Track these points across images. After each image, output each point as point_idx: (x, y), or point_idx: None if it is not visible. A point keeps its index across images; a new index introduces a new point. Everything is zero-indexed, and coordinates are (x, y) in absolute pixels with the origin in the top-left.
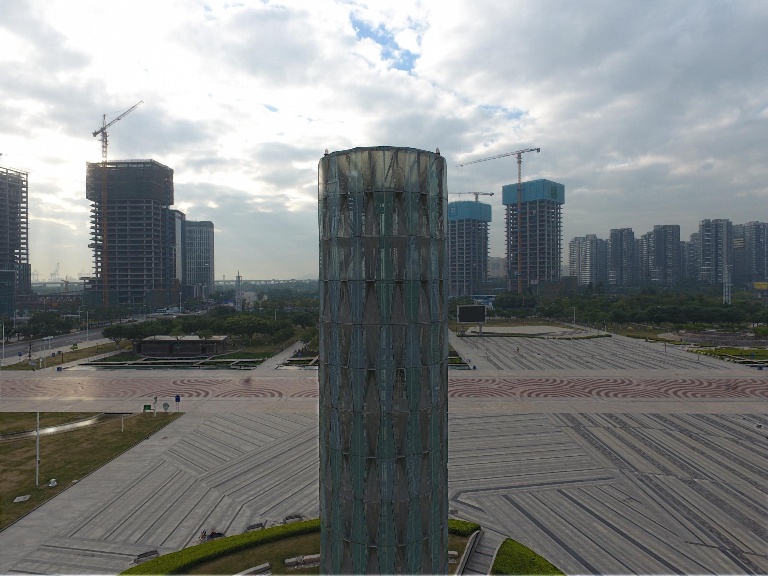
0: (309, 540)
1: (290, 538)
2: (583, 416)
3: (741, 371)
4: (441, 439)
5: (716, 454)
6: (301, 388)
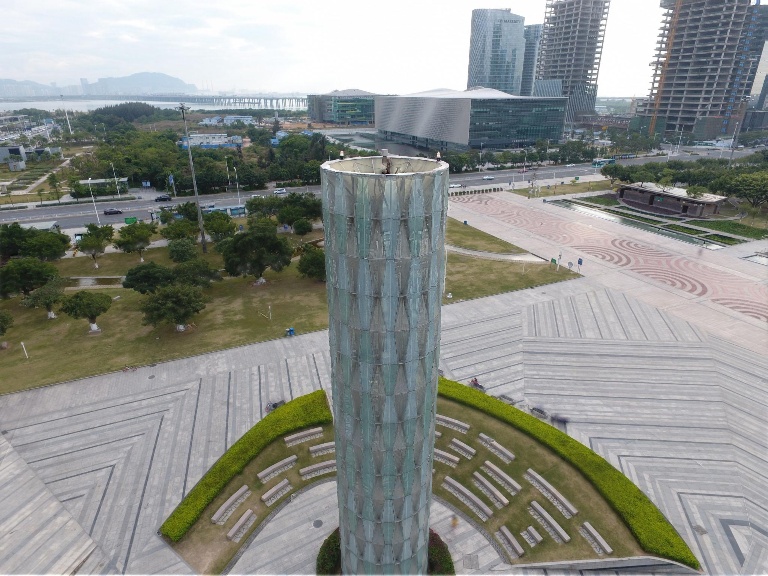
0: (511, 434)
1: (502, 422)
2: None
3: None
4: (380, 419)
5: None
6: (741, 295)
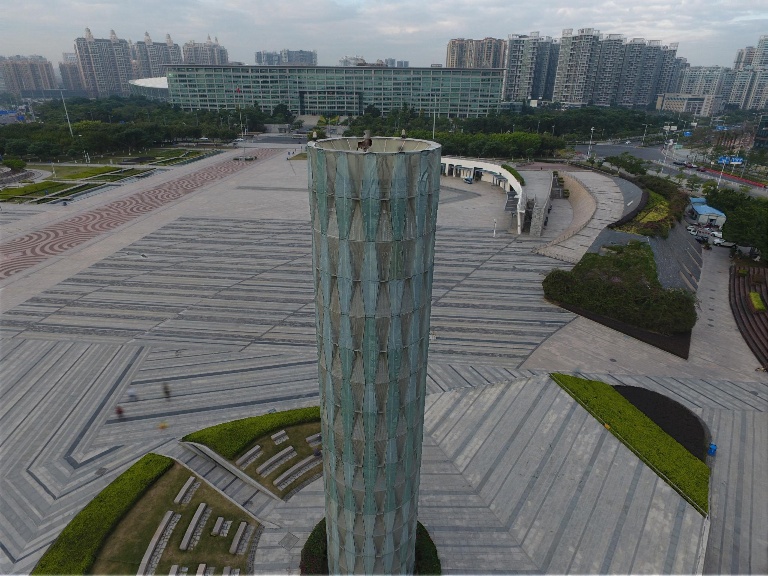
0: None
1: None
2: (14, 314)
3: (56, 211)
4: None
5: (159, 289)
6: None
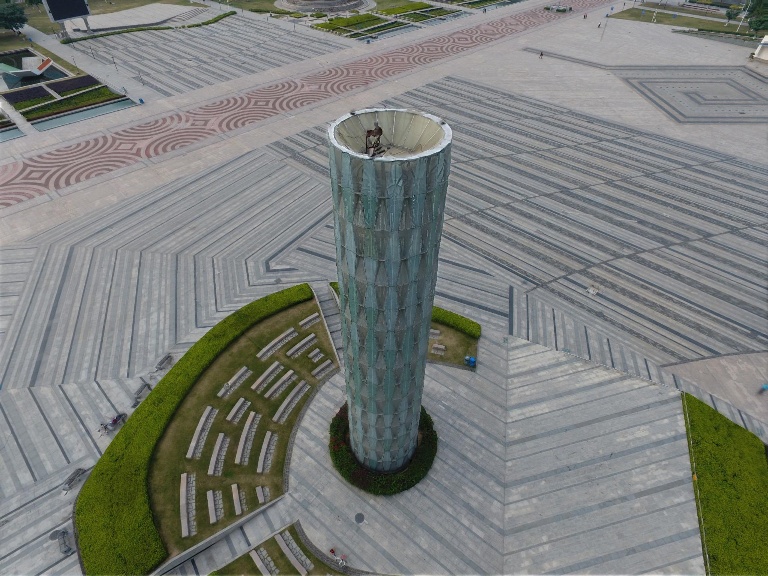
0: (216, 371)
1: (200, 379)
2: (290, 141)
3: (359, 48)
4: None
5: None
6: None
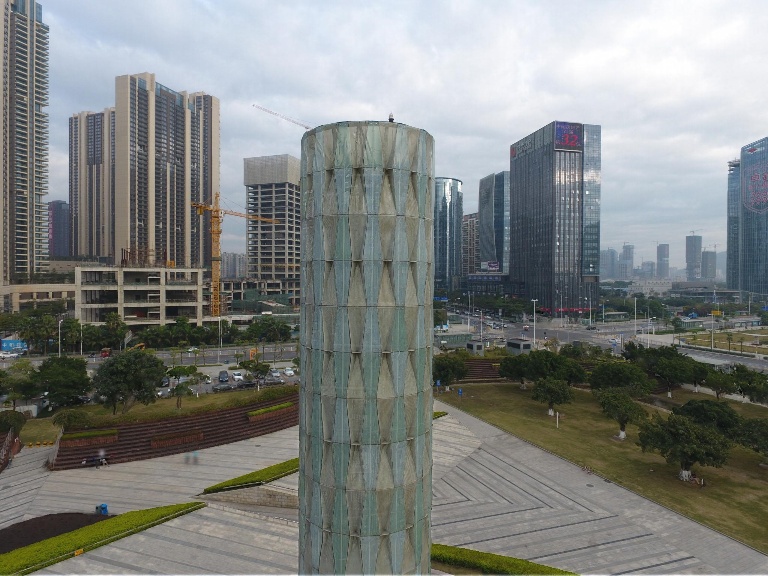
0: None
1: None
2: None
3: None
4: None
5: None
6: None
